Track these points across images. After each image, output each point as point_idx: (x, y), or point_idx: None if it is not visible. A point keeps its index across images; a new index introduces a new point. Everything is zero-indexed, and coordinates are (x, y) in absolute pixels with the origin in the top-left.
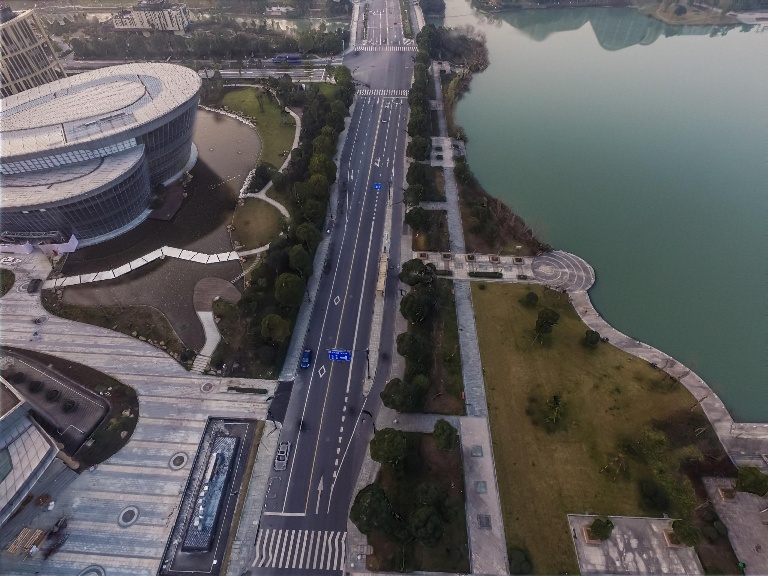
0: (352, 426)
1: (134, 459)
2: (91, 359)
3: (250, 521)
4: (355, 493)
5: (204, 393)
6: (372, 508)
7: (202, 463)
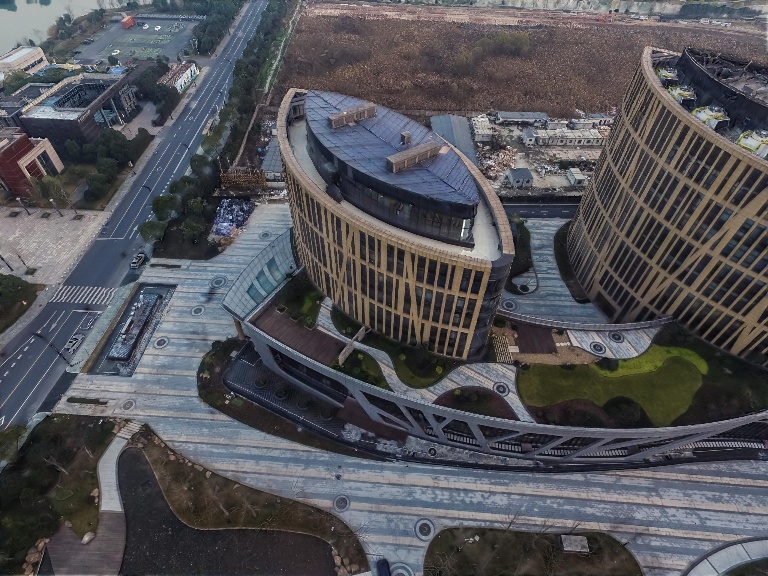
0: (2, 367)
1: (197, 344)
2: (257, 439)
3: (113, 308)
4: (30, 321)
5: (132, 399)
6: (4, 277)
7: (144, 343)
